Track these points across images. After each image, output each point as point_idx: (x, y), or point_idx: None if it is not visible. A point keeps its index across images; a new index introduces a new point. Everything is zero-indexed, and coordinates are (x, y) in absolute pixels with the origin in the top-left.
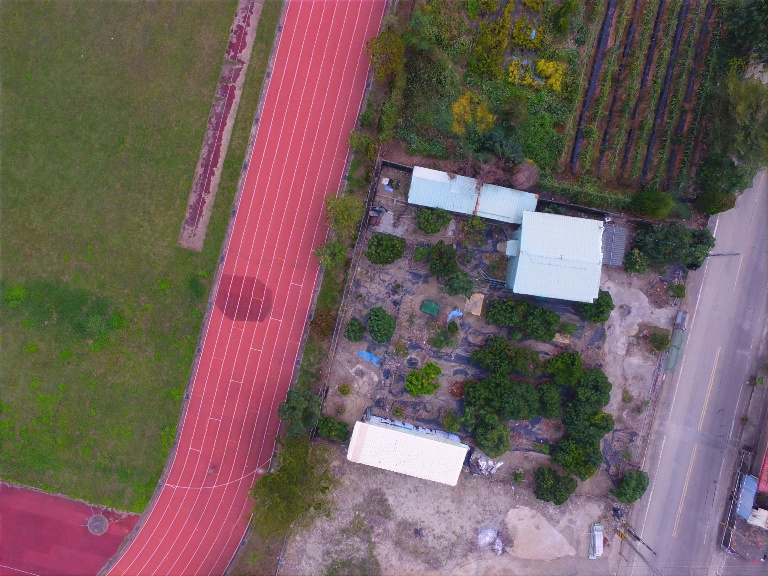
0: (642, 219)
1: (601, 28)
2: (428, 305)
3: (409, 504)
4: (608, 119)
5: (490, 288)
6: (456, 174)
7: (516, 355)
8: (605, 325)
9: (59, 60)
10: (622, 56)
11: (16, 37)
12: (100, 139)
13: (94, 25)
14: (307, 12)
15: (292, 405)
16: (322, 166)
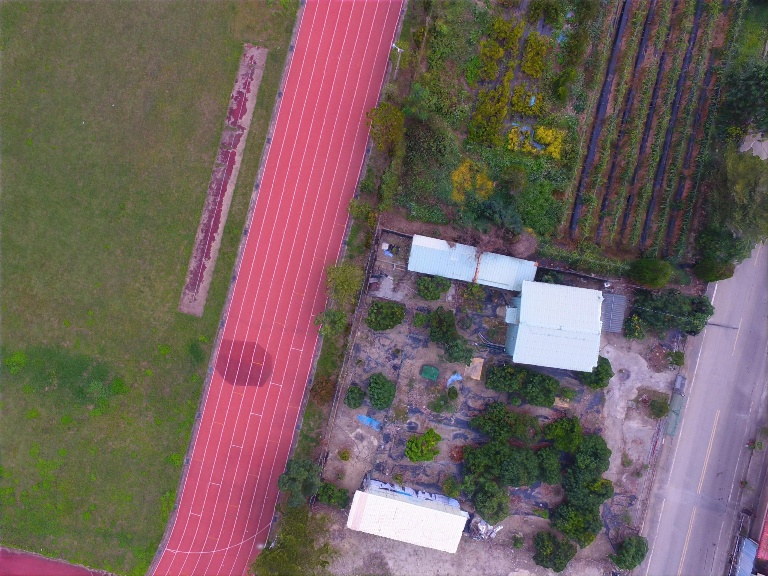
0: (641, 287)
1: (600, 94)
2: (428, 370)
3: (409, 568)
4: (607, 185)
5: (490, 352)
6: (456, 242)
7: (515, 422)
8: (604, 389)
9: (60, 127)
10: (621, 122)
11: (17, 104)
12: (101, 205)
13: (95, 92)
14: (307, 78)
15: (292, 476)
16: (322, 231)
